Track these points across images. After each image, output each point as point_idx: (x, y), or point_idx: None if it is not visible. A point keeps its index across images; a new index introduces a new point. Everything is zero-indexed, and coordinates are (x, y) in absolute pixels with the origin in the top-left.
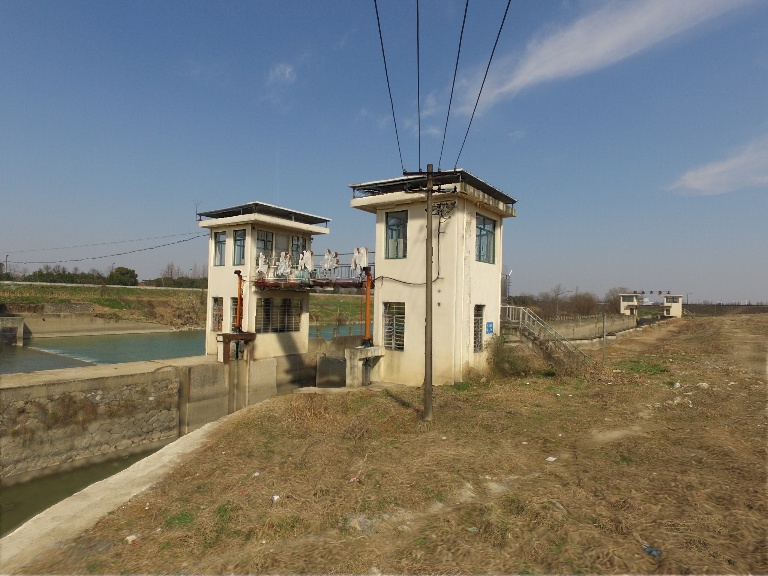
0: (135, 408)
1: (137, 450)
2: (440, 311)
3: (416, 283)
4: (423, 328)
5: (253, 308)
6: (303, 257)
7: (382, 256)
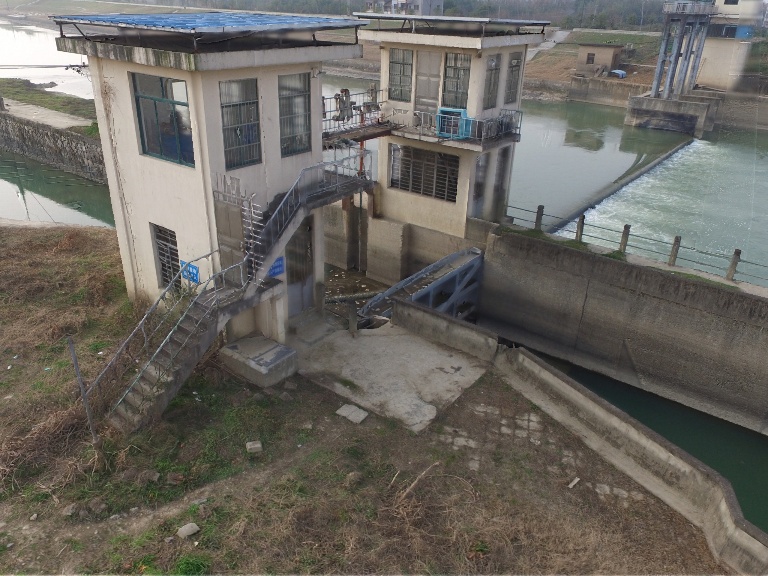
0: None
1: None
2: None
3: None
4: None
5: (385, 155)
6: None
7: None
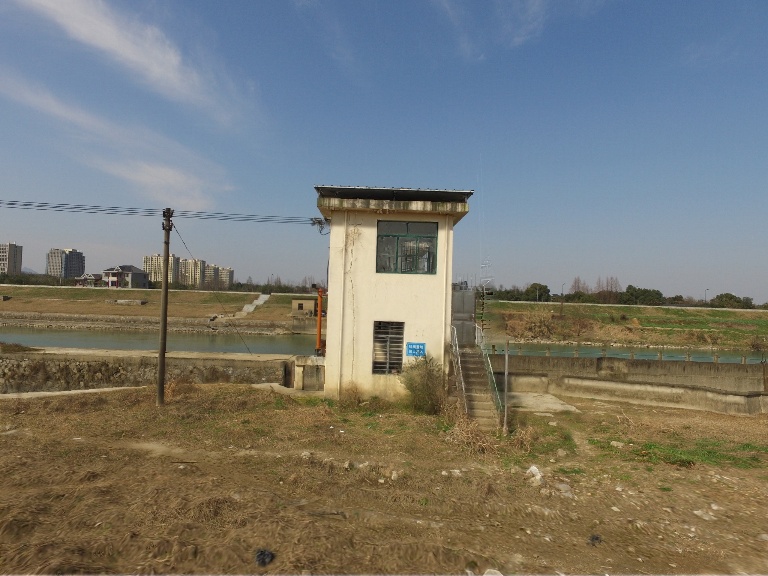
0: None
1: None
2: None
3: None
4: None
5: None
6: None
7: None
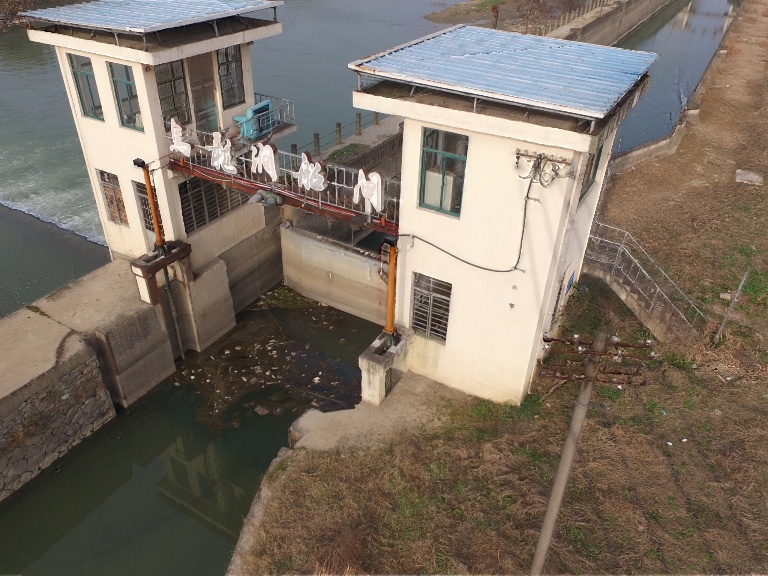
0: (48, 418)
1: (69, 457)
2: (512, 315)
3: (475, 264)
4: (480, 328)
5: (176, 202)
6: (259, 153)
7: (414, 202)
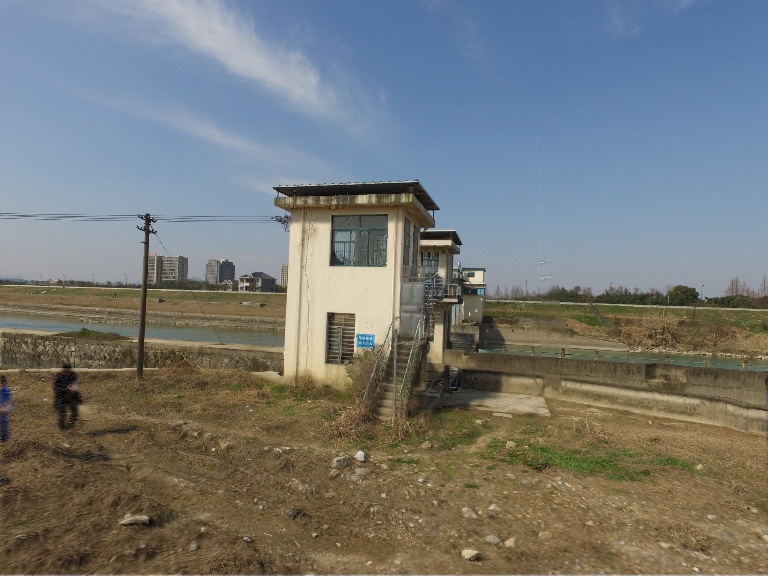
0: None
1: None
2: None
3: None
4: None
5: None
6: None
7: None
